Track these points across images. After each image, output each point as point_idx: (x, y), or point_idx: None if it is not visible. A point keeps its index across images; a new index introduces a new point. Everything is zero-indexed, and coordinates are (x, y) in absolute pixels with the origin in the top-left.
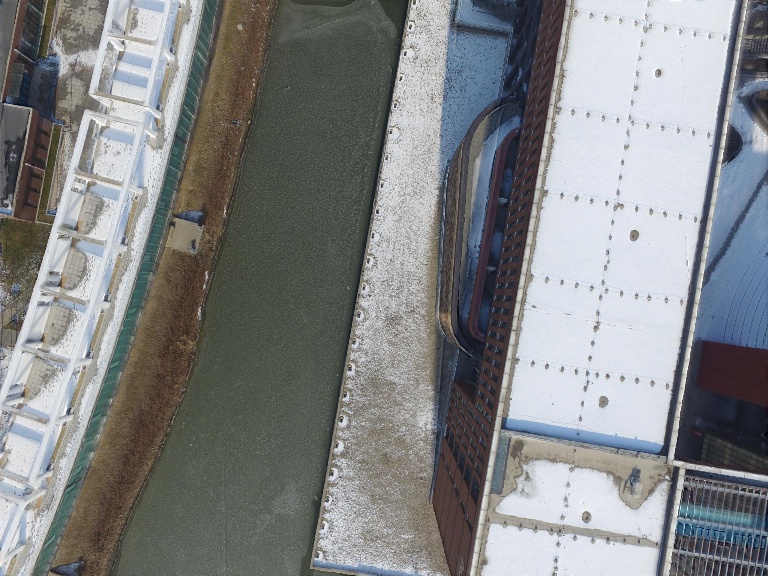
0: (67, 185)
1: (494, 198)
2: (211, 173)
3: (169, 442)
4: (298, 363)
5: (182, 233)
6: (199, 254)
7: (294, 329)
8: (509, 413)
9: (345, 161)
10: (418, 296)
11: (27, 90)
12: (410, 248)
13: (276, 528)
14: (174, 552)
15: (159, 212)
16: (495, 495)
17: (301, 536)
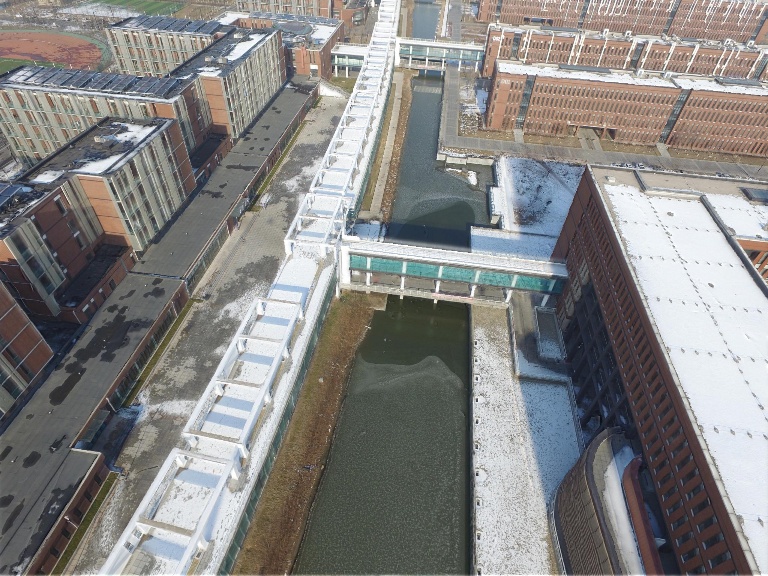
0: (123, 537)
1: (649, 538)
2: (276, 527)
3: None
4: None
5: None
6: None
7: None
8: None
9: (429, 509)
10: None
11: (97, 437)
12: None
13: None
14: None
15: None
16: None
17: None
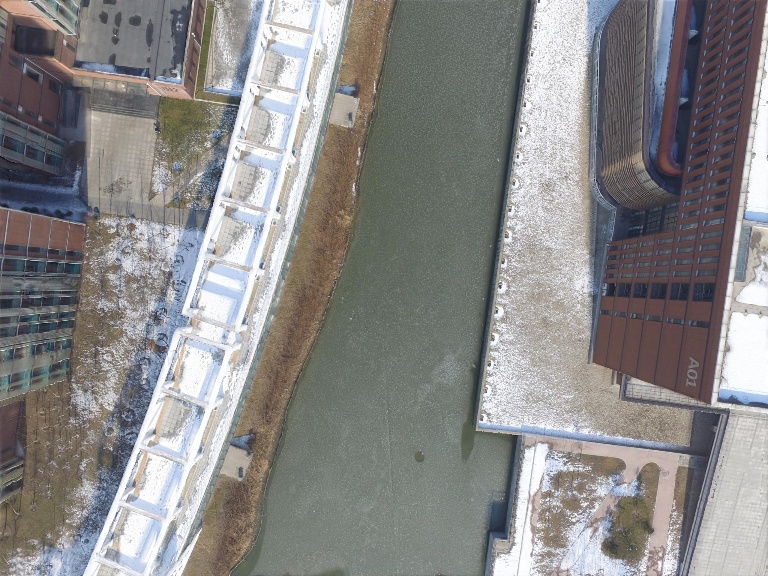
0: (259, 35)
1: (685, 30)
2: (362, 48)
3: (329, 317)
4: (452, 235)
5: (338, 106)
6: (352, 130)
7: (447, 202)
8: (747, 206)
9: (491, 34)
10: (571, 162)
11: None
12: (562, 115)
13: (436, 396)
14: (338, 423)
15: None
16: (736, 285)
17: (461, 403)
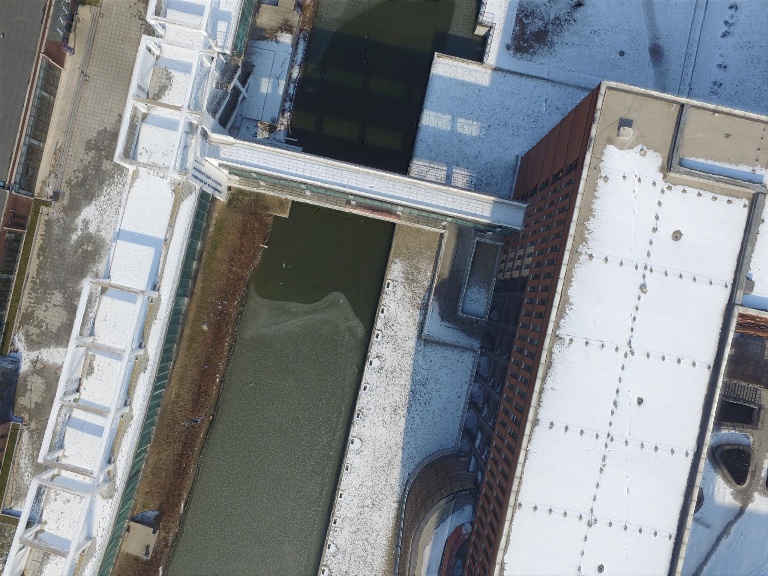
0: (11, 555)
1: None
2: (169, 473)
3: None
4: None
5: (136, 538)
6: (154, 552)
7: None
8: None
9: (306, 461)
10: None
11: None
12: (366, 561)
13: None
14: None
15: (108, 553)
16: None
17: None
